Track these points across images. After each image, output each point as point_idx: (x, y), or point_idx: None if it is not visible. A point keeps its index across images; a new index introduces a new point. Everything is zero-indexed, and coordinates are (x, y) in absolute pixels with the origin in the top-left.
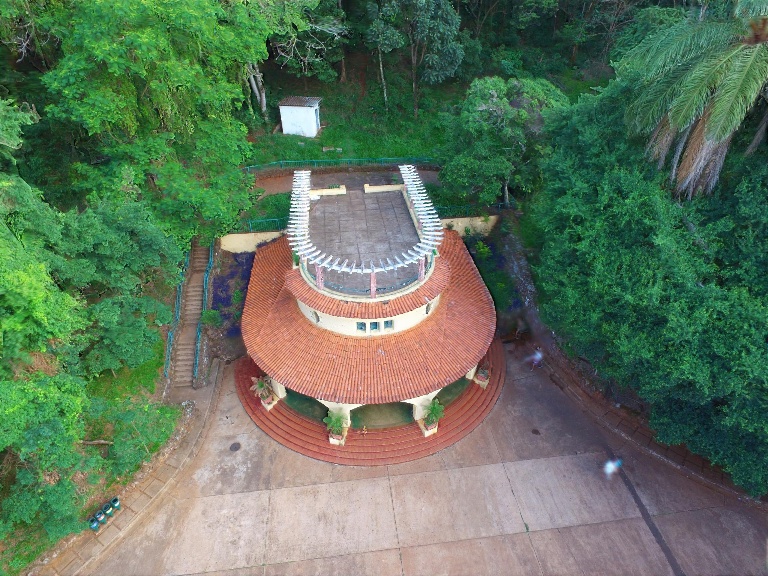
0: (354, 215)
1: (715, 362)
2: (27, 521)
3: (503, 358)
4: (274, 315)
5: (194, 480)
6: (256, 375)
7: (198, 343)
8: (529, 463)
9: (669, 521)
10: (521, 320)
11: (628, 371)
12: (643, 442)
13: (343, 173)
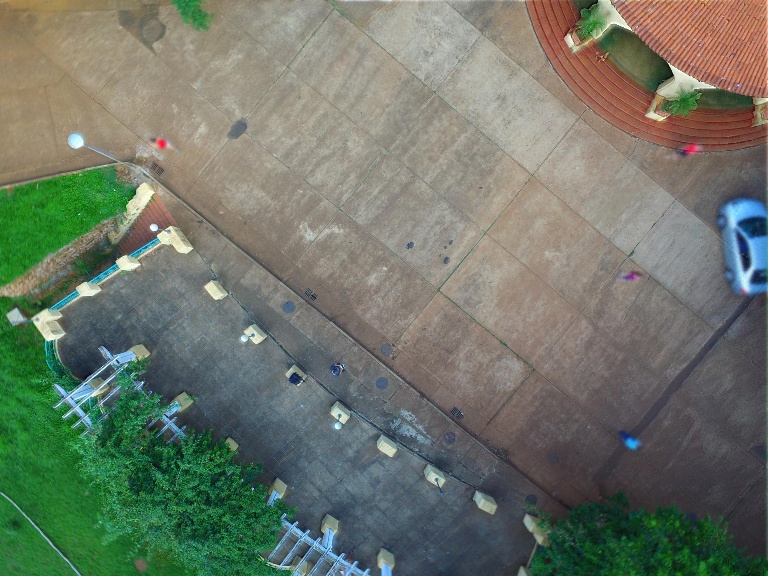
0: None
1: None
2: None
3: None
4: None
5: None
6: None
7: None
8: (695, 221)
9: (729, 351)
10: None
11: None
12: None
13: None
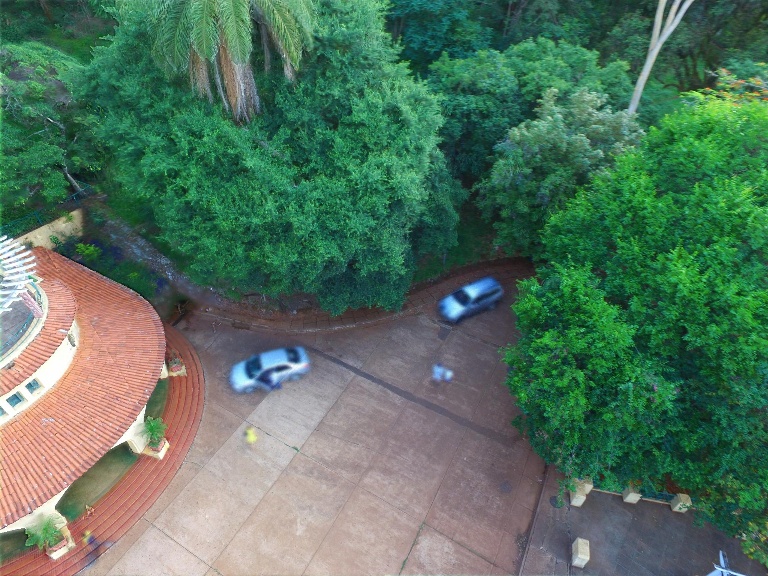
0: None
1: (335, 237)
2: None
3: (183, 339)
4: None
5: None
6: None
7: None
8: (264, 403)
9: (370, 363)
10: (175, 296)
11: (289, 279)
12: (325, 326)
13: None
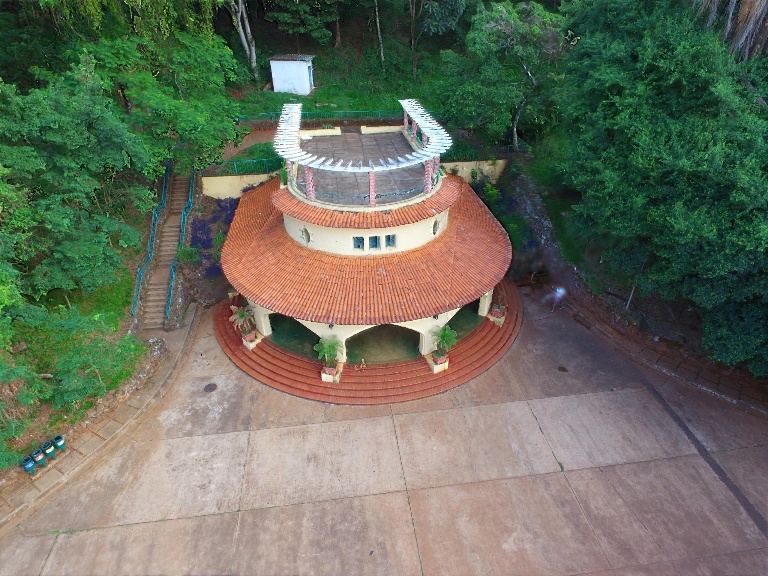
0: (350, 149)
1: None
2: None
3: (519, 300)
4: (258, 243)
5: (159, 422)
6: None
7: (172, 281)
8: (558, 400)
9: (732, 457)
10: (537, 262)
11: (682, 264)
12: (689, 377)
13: (338, 126)
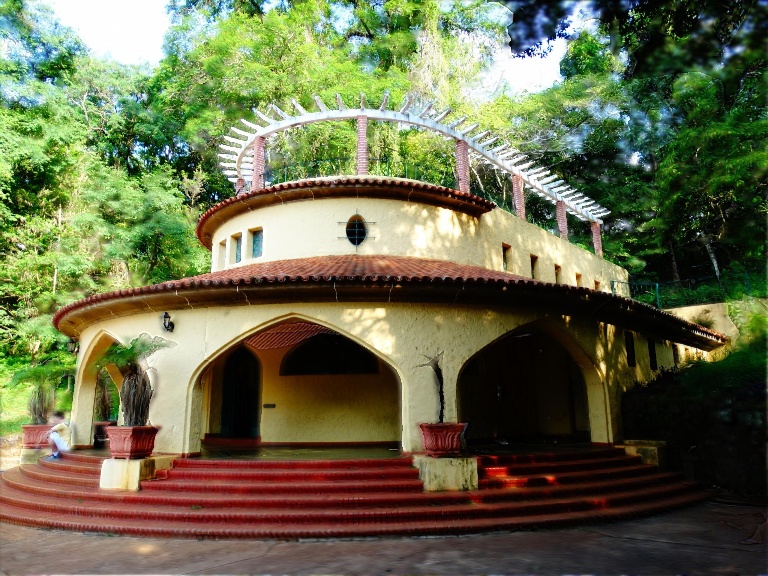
0: None
1: None
2: None
3: (648, 503)
4: None
5: None
6: None
7: None
8: None
9: None
10: None
11: None
12: None
13: None
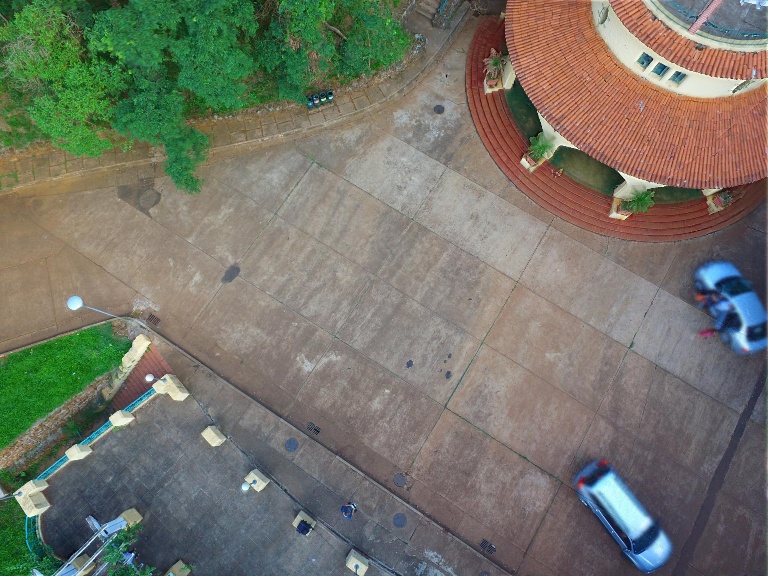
0: None
1: None
2: (268, 70)
3: (762, 197)
4: None
5: (393, 117)
6: (495, 47)
7: None
8: (684, 305)
9: (762, 435)
10: None
11: None
12: None
13: None
